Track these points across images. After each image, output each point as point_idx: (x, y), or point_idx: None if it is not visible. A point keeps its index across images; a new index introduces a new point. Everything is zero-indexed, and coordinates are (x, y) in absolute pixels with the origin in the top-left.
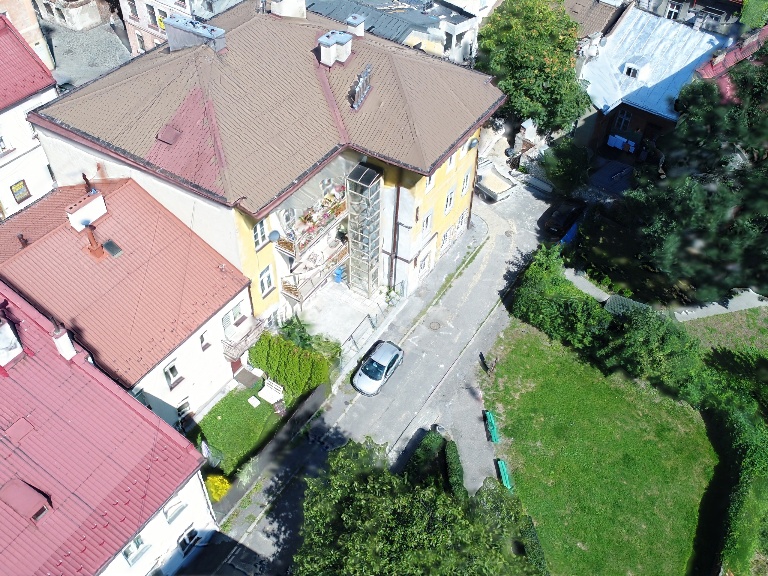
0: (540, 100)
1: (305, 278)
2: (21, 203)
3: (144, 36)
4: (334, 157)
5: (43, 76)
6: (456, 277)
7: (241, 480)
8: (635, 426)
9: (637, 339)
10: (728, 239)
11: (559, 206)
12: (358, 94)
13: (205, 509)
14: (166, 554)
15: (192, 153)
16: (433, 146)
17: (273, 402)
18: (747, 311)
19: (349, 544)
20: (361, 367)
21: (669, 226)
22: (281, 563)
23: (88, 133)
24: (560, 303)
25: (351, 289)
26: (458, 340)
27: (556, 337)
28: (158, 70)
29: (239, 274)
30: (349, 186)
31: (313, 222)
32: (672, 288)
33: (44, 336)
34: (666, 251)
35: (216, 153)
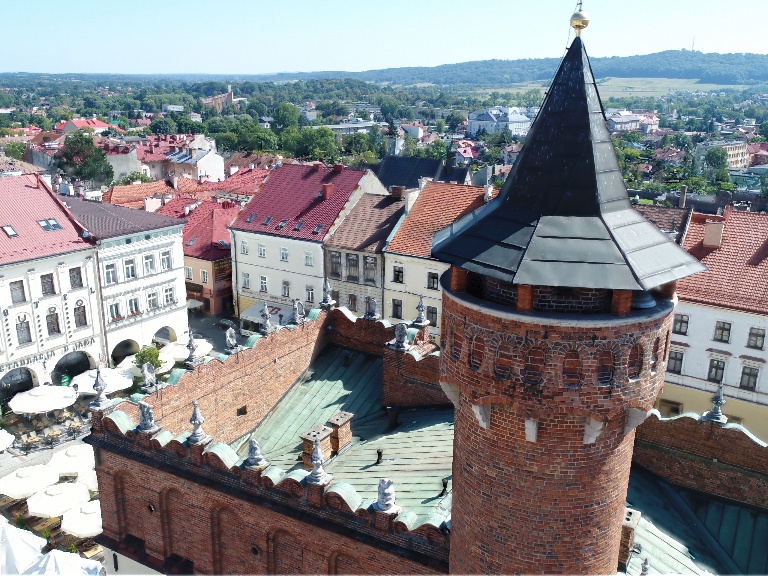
0: None
1: None
2: None
3: None
4: None
5: None
6: None
7: None
8: None
9: None
10: None
11: None
12: None
13: None
14: None
15: None
16: None
17: None
18: None
19: None
20: None
21: None
22: None
23: None
24: None
25: None
26: None
27: None
28: None
29: None
30: None
31: None
32: None
33: None
34: None
35: None
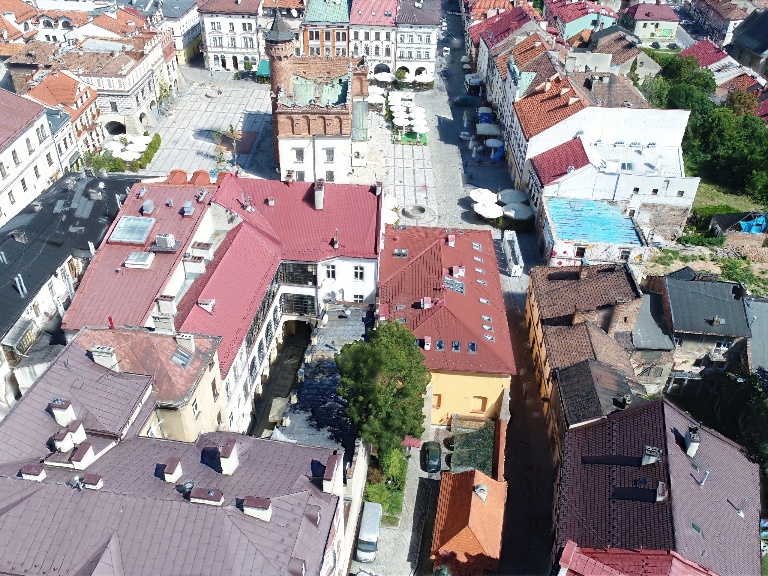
0: None
1: None
2: None
3: None
4: None
5: None
6: None
7: None
8: None
9: None
10: None
11: None
12: None
13: None
14: None
15: None
16: None
17: None
18: None
19: None
20: None
21: None
22: None
23: None
24: (540, 0)
25: None
26: None
27: None
28: None
29: None
30: None
31: None
32: None
33: None
34: None
35: None
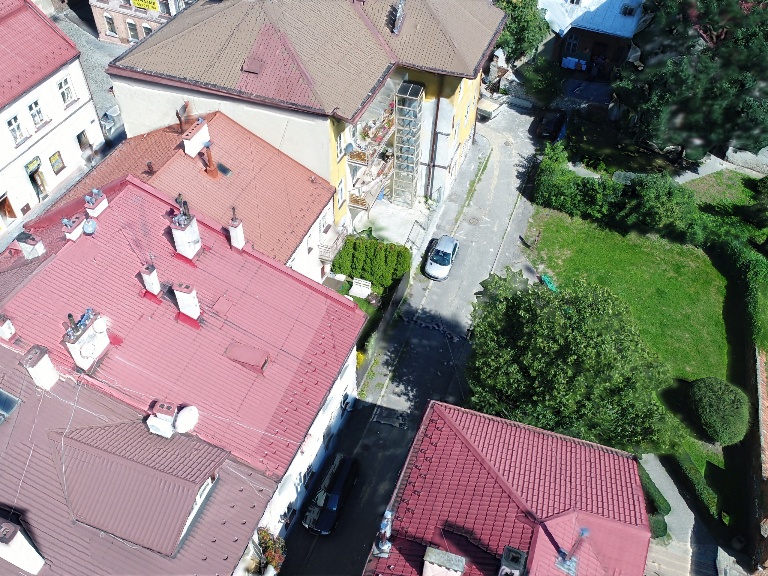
0: (509, 29)
1: (366, 190)
2: (58, 174)
3: (114, 17)
4: (390, 74)
5: (68, 48)
6: (477, 182)
7: (368, 353)
8: (657, 268)
9: (651, 196)
10: (711, 101)
11: (543, 116)
12: (398, 19)
13: (354, 373)
14: (335, 412)
15: (280, 78)
16: (470, 56)
17: (364, 297)
18: (714, 174)
19: (537, 327)
20: (430, 258)
21: (665, 98)
22: (418, 413)
23: (173, 75)
24: (578, 182)
25: (393, 203)
26: (497, 229)
27: (577, 213)
28: (224, 14)
29: (327, 184)
30: (397, 102)
31: (370, 138)
32: (652, 166)
33: (212, 234)
34: (661, 122)
35: (302, 75)
